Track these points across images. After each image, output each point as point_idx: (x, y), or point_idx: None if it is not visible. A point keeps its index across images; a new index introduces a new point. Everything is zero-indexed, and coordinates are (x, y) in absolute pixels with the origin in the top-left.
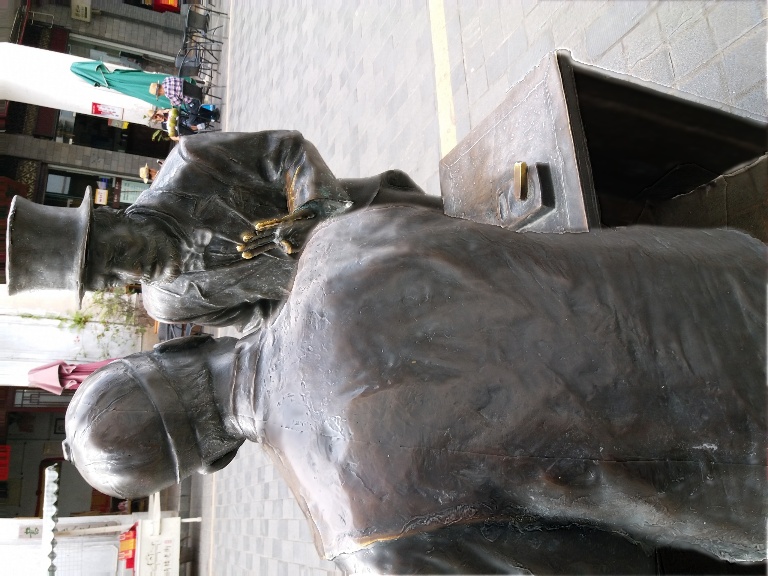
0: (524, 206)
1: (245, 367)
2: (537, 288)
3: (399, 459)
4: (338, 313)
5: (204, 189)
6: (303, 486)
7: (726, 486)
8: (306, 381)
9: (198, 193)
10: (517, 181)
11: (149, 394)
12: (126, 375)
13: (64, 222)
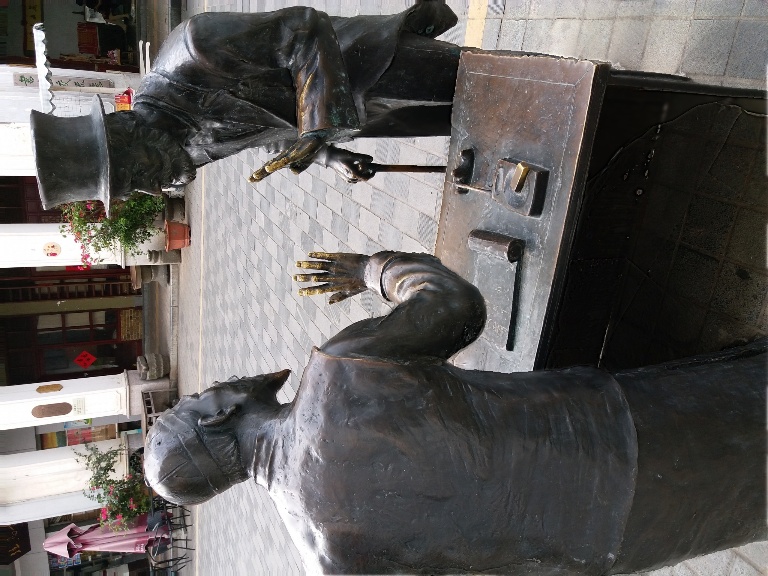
0: (516, 197)
1: (262, 453)
2: (464, 472)
3: (354, 557)
4: (329, 457)
5: (213, 84)
6: (297, 546)
7: (539, 571)
8: (303, 490)
9: (206, 87)
10: (516, 179)
11: (198, 467)
12: (180, 442)
13: (83, 149)
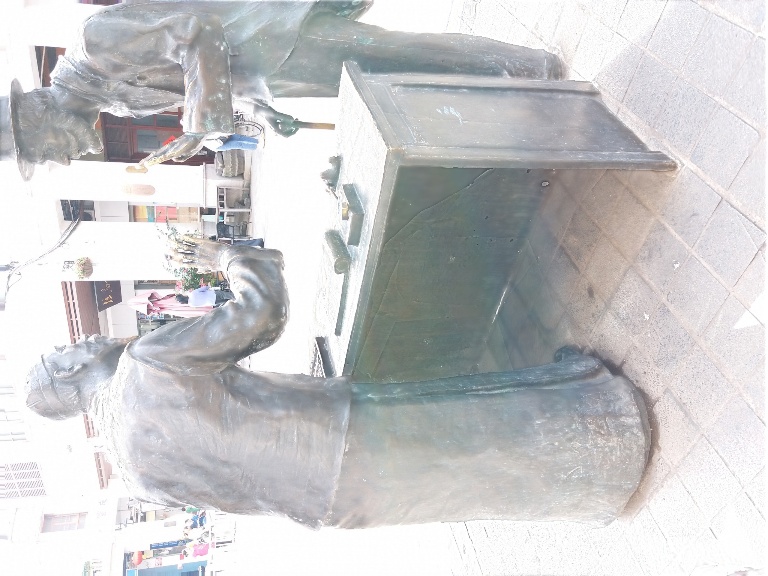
0: (346, 223)
1: (92, 404)
2: (209, 455)
3: None
4: (124, 424)
5: (111, 77)
6: (113, 466)
7: None
8: None
9: (107, 79)
10: None
11: (50, 405)
12: (39, 386)
13: None
